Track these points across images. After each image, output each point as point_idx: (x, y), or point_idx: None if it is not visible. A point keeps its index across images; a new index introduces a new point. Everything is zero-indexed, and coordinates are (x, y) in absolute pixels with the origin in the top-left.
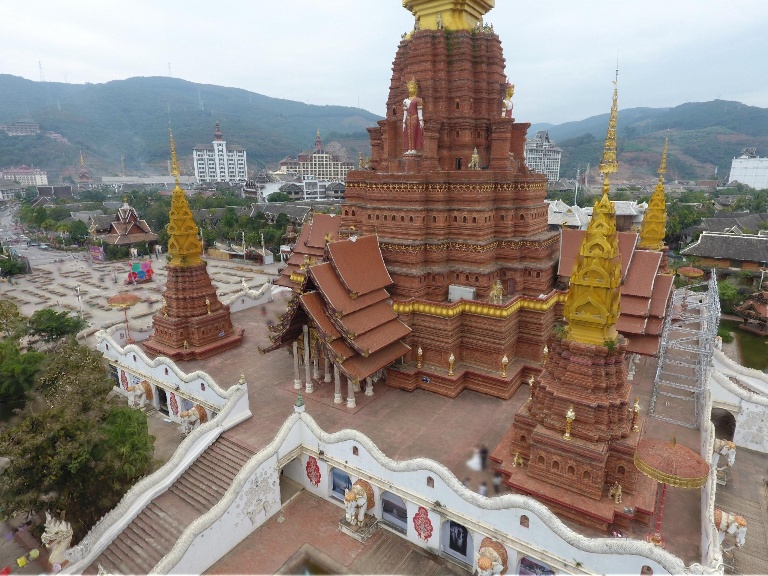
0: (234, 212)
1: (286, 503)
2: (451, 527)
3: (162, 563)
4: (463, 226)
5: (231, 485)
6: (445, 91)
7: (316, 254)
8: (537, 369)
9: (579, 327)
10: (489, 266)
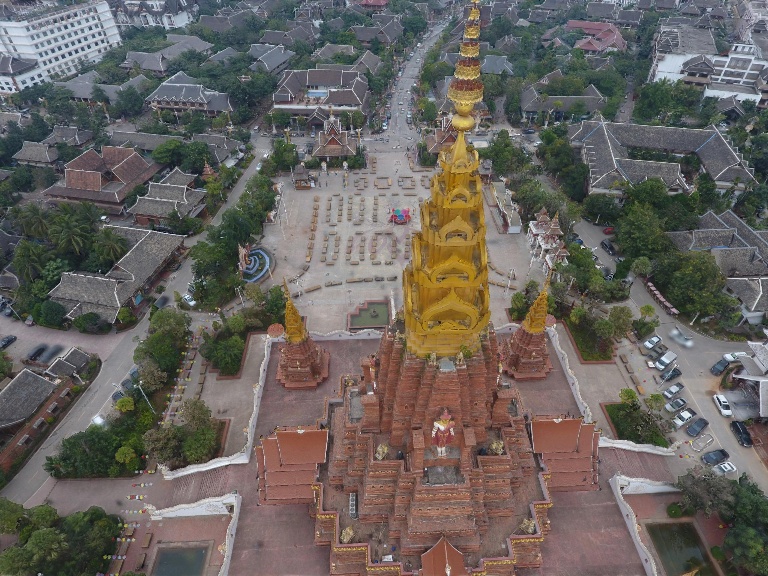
0: (582, 108)
1: (232, 513)
2: None
3: (169, 509)
4: None
5: (198, 502)
6: (390, 384)
7: None
8: None
9: None
10: (379, 506)
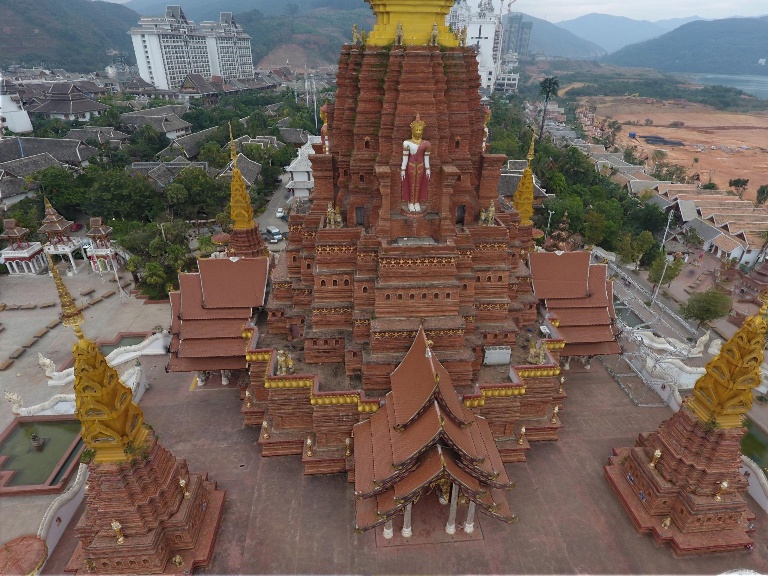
0: None
1: None
2: None
3: None
4: (487, 286)
5: None
6: (447, 128)
7: (228, 318)
8: (558, 397)
9: (724, 416)
10: None
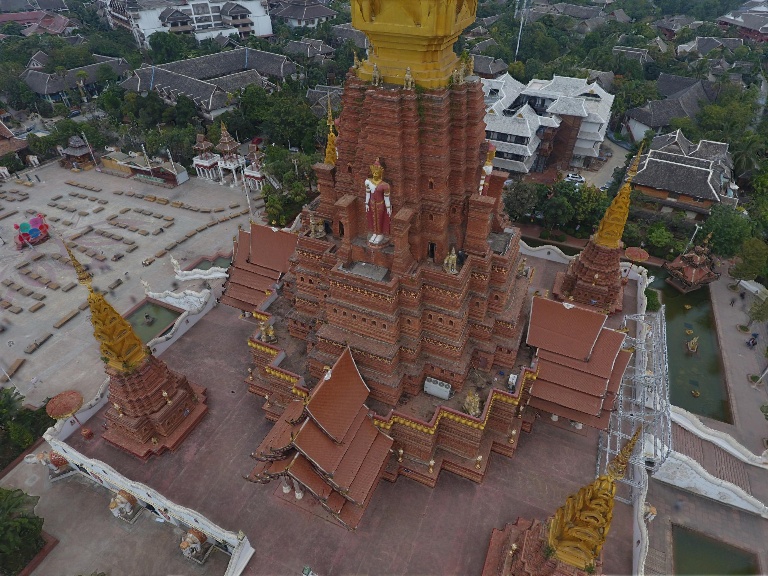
0: (111, 72)
1: None
2: None
3: None
4: (438, 325)
5: None
6: (417, 171)
7: (263, 275)
8: (505, 446)
9: None
10: (463, 351)
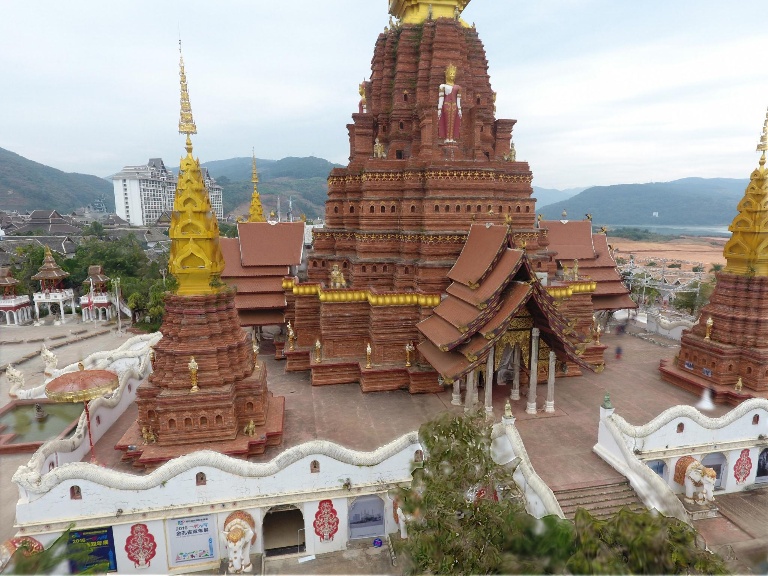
0: None
1: None
2: (761, 455)
3: None
4: (517, 216)
5: None
6: None
7: (266, 275)
8: None
9: (758, 265)
10: None
